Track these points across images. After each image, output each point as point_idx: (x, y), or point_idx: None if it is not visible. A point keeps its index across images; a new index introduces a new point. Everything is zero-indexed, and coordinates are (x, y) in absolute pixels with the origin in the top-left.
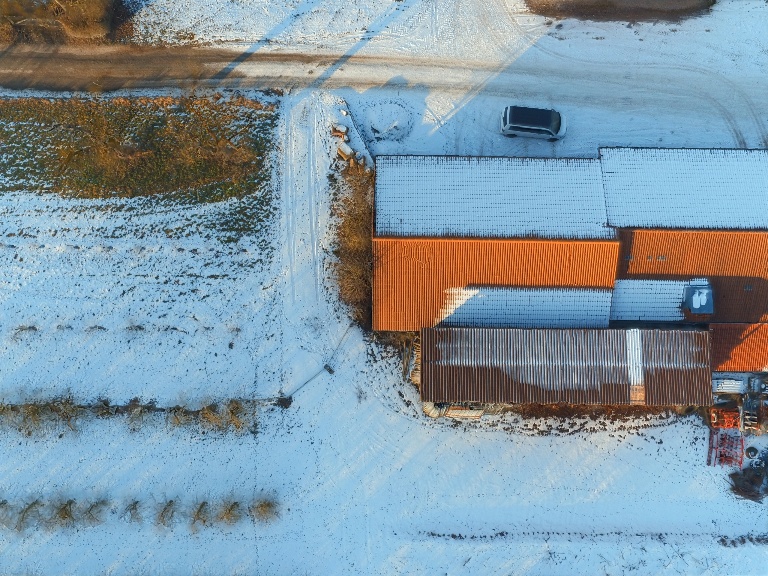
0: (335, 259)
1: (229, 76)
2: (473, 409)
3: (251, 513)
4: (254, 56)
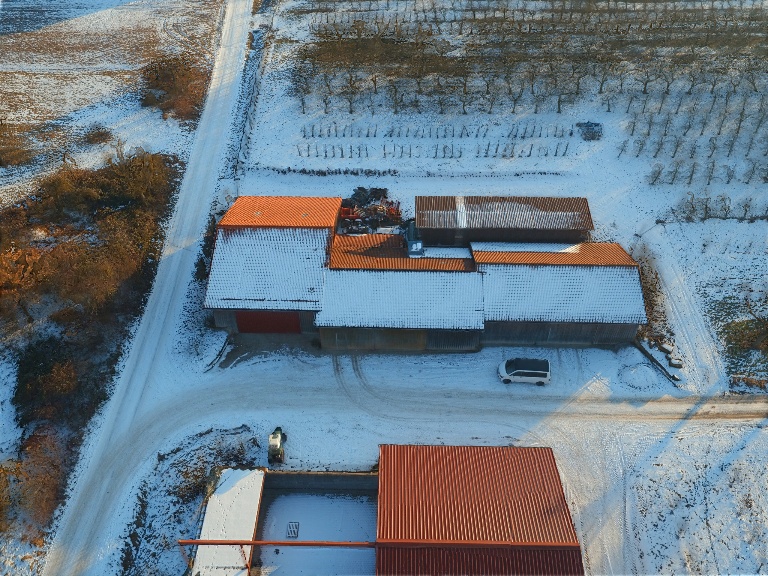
0: None
1: None
2: None
3: (661, 181)
4: (766, 416)
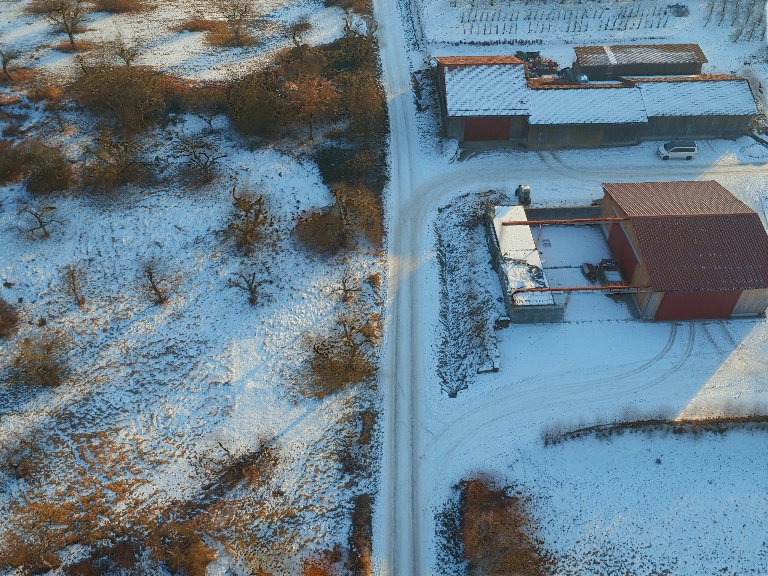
0: None
1: None
2: None
3: None
4: None
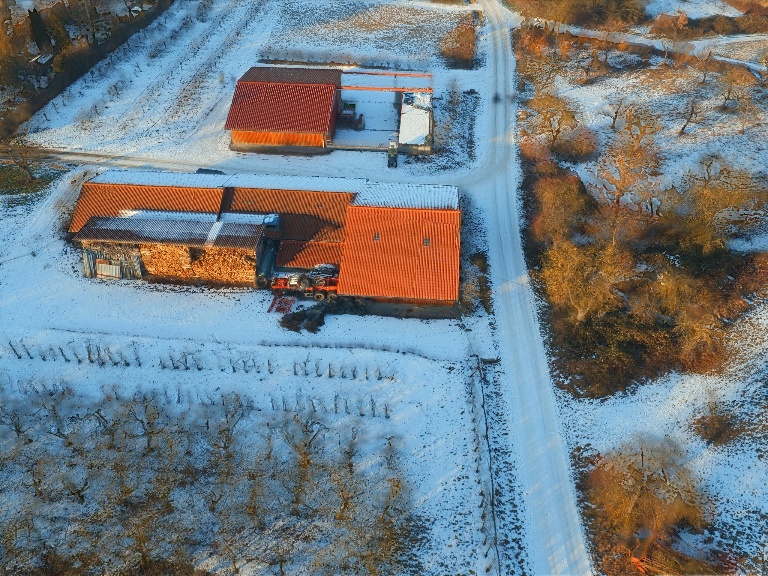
0: (67, 216)
1: (52, 159)
2: (112, 264)
3: None
4: (70, 153)
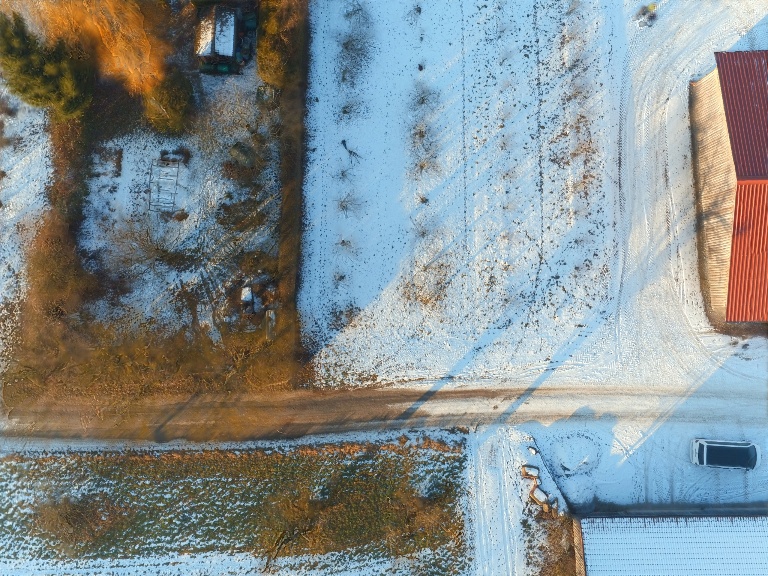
0: None
1: (413, 416)
2: None
3: None
4: (438, 394)
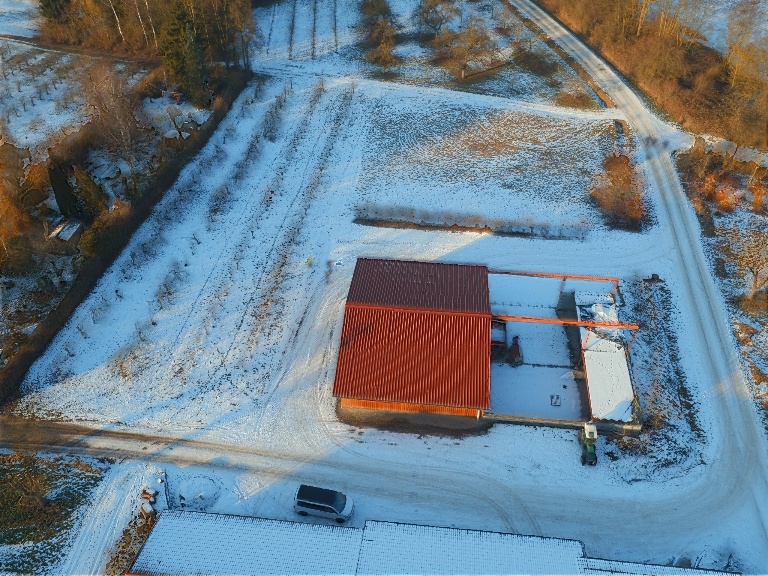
0: None
1: (76, 445)
2: None
3: None
4: (103, 433)
